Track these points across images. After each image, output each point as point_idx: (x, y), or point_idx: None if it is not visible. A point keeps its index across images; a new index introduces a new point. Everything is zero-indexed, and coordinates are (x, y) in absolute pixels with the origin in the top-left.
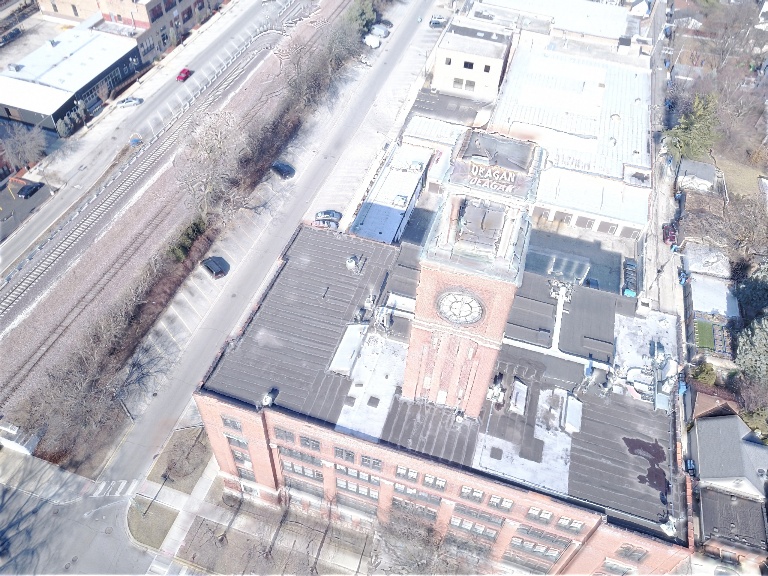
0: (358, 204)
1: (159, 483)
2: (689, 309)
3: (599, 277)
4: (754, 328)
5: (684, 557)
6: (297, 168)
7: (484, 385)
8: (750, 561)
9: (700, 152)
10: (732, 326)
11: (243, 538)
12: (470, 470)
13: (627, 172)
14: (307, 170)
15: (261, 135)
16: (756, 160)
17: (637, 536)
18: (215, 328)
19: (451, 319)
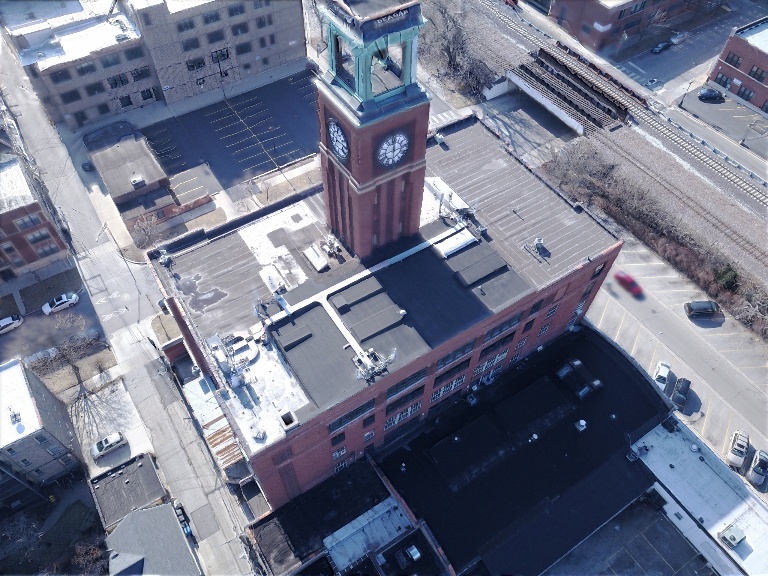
0: None
1: None
2: None
3: None
4: None
5: None
6: None
7: None
8: None
9: None
10: None
11: None
12: (302, 197)
13: None
14: None
15: None
16: None
17: None
18: (617, 281)
19: None
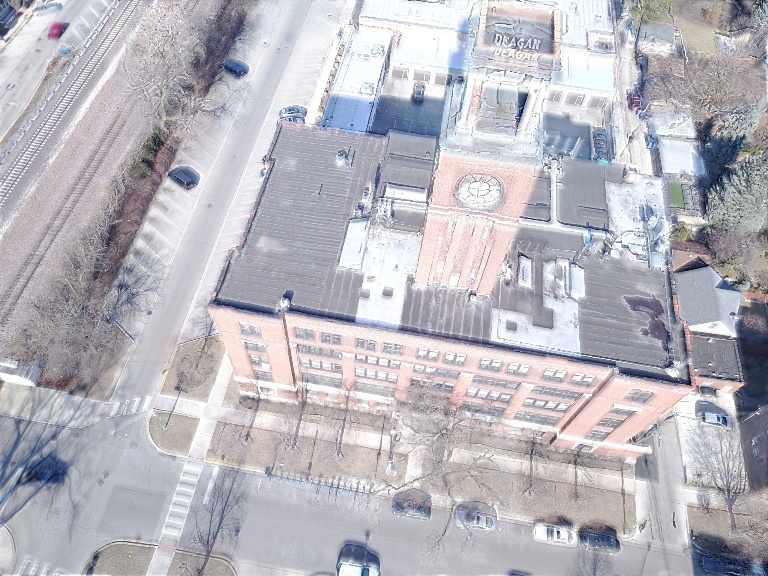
0: (322, 96)
1: (174, 396)
2: (658, 172)
3: None
4: (722, 183)
5: (686, 394)
6: (250, 63)
7: (498, 262)
8: (724, 393)
9: (659, 11)
10: (699, 184)
11: (267, 435)
12: (490, 343)
13: (590, 38)
14: (261, 64)
15: (205, 28)
16: (710, 16)
17: (646, 381)
18: (198, 240)
19: (469, 200)
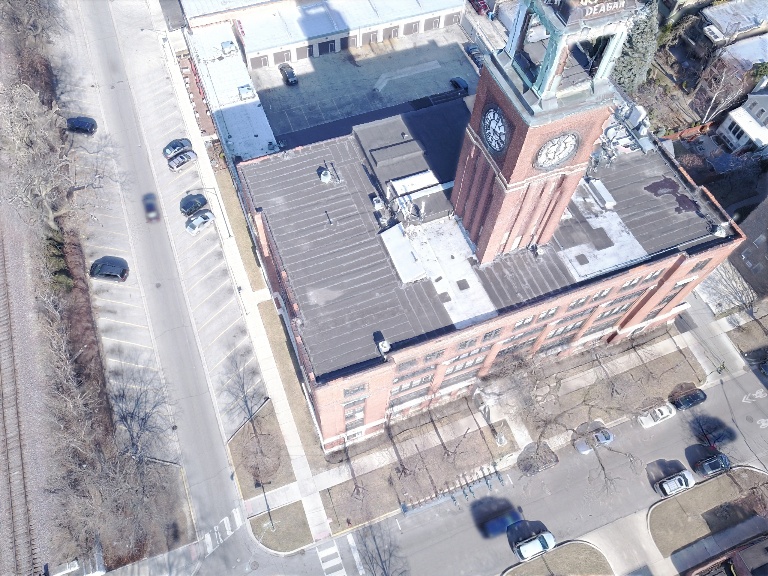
0: (196, 119)
1: (259, 494)
2: None
3: (456, 73)
4: None
5: None
6: (92, 115)
7: (562, 209)
8: None
9: None
10: None
11: (374, 476)
12: (578, 285)
13: None
14: (105, 111)
15: None
16: None
17: (709, 252)
18: (171, 328)
19: (545, 165)
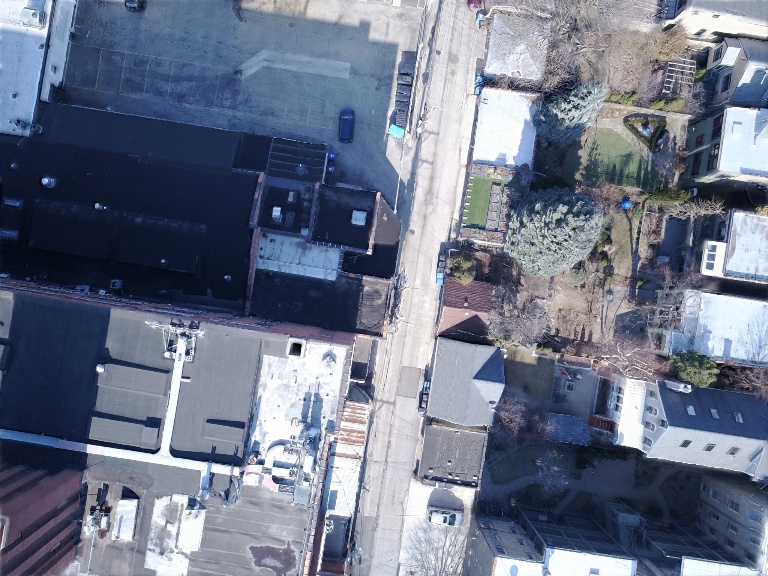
0: None
1: None
2: None
3: (360, 101)
4: None
5: None
6: None
7: None
8: None
9: None
10: (517, 183)
11: None
12: None
13: None
14: None
15: None
16: None
17: None
18: None
19: None
